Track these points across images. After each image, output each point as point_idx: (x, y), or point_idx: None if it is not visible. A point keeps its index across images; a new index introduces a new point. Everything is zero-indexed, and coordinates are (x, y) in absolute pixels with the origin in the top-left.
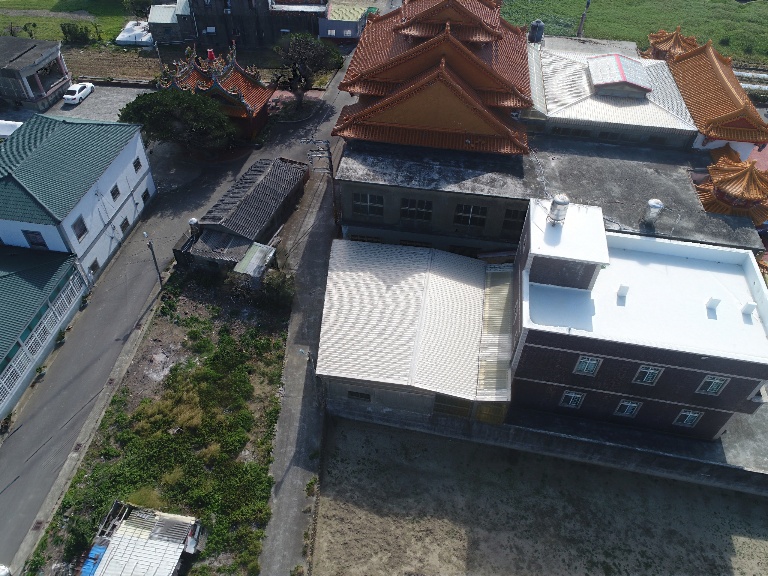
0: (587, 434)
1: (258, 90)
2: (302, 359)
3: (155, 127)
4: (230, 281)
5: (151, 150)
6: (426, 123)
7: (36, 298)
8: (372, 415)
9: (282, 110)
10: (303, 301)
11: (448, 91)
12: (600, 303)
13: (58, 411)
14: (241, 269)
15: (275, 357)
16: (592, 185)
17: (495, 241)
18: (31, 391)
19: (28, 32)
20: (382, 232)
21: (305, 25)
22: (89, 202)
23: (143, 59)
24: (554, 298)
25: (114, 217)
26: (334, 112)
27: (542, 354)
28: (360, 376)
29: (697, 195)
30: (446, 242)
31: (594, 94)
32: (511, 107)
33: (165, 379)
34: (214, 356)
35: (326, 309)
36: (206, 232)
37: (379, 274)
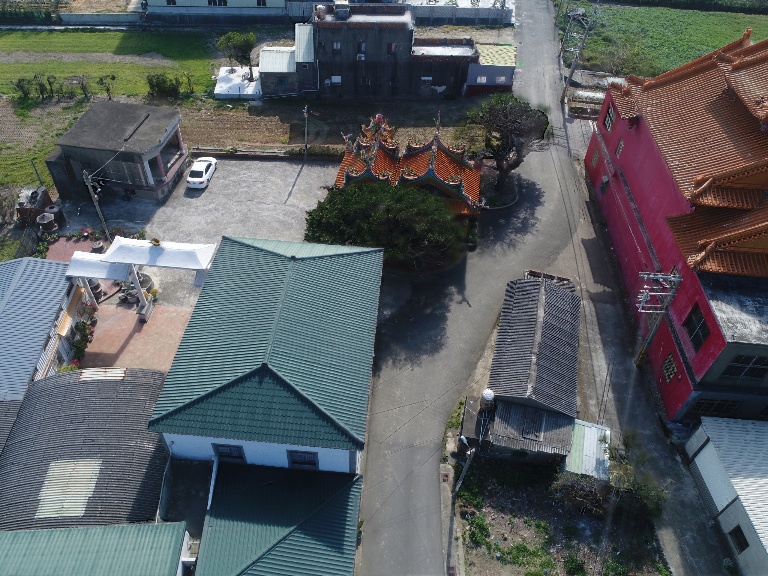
0: None
1: (466, 172)
2: None
3: (376, 242)
4: (560, 485)
5: None
6: None
7: (342, 572)
8: None
9: None
10: None
11: None
12: None
13: None
14: (576, 467)
15: None
16: None
17: None
18: None
19: (104, 86)
20: (749, 396)
21: (451, 71)
22: None
23: (257, 118)
24: None
25: None
26: (541, 191)
27: None
28: None
29: None
30: None
31: None
32: None
33: None
34: None
35: None
36: (502, 406)
37: None
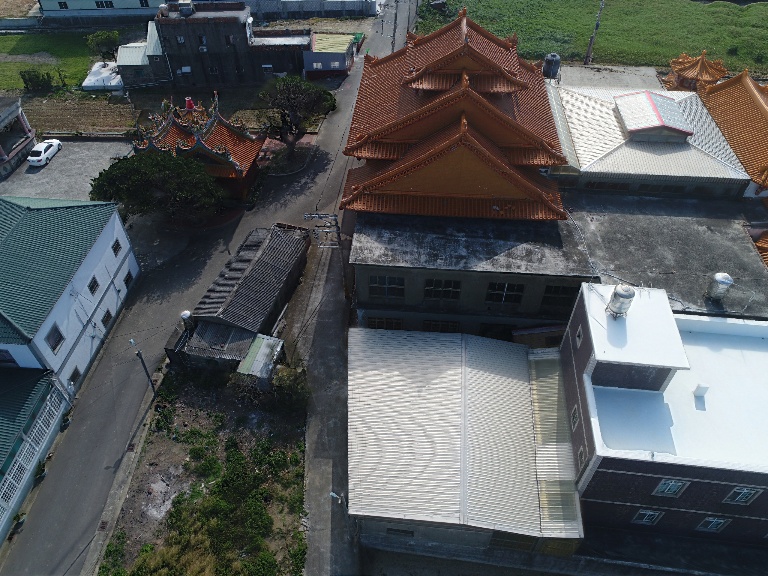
0: (666, 554)
1: (246, 144)
2: (325, 478)
3: (134, 199)
4: (234, 383)
5: (131, 224)
6: (447, 189)
7: (7, 434)
8: (414, 547)
9: (272, 161)
10: (319, 400)
11: (472, 155)
12: (676, 408)
13: (42, 572)
14: (246, 369)
15: (293, 476)
16: (641, 252)
17: (533, 318)
18: (8, 546)
19: None
20: (403, 313)
21: (288, 59)
22: (64, 305)
23: (114, 106)
24: (622, 405)
25: (94, 313)
26: (330, 160)
27: (617, 478)
28: (402, 514)
29: (761, 257)
30: (476, 320)
31: (629, 140)
32: (542, 165)
33: (167, 516)
34: (222, 481)
35: (351, 423)
36: (201, 325)
37: (407, 372)
